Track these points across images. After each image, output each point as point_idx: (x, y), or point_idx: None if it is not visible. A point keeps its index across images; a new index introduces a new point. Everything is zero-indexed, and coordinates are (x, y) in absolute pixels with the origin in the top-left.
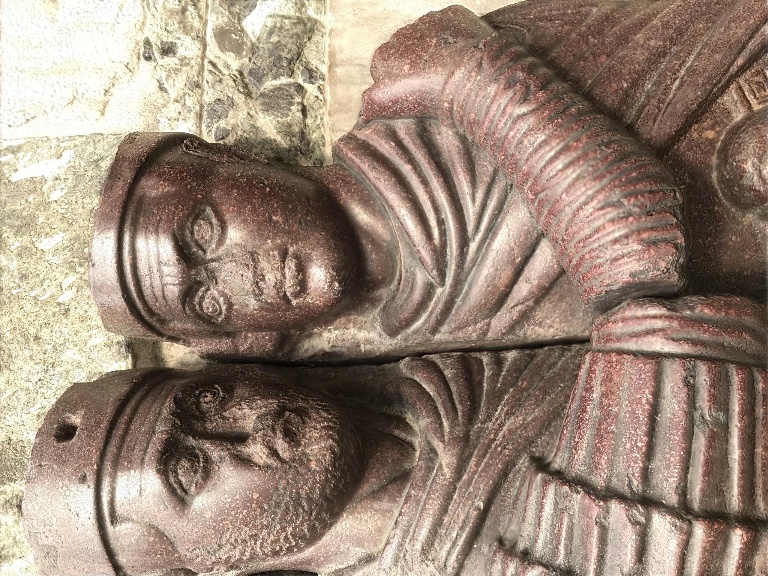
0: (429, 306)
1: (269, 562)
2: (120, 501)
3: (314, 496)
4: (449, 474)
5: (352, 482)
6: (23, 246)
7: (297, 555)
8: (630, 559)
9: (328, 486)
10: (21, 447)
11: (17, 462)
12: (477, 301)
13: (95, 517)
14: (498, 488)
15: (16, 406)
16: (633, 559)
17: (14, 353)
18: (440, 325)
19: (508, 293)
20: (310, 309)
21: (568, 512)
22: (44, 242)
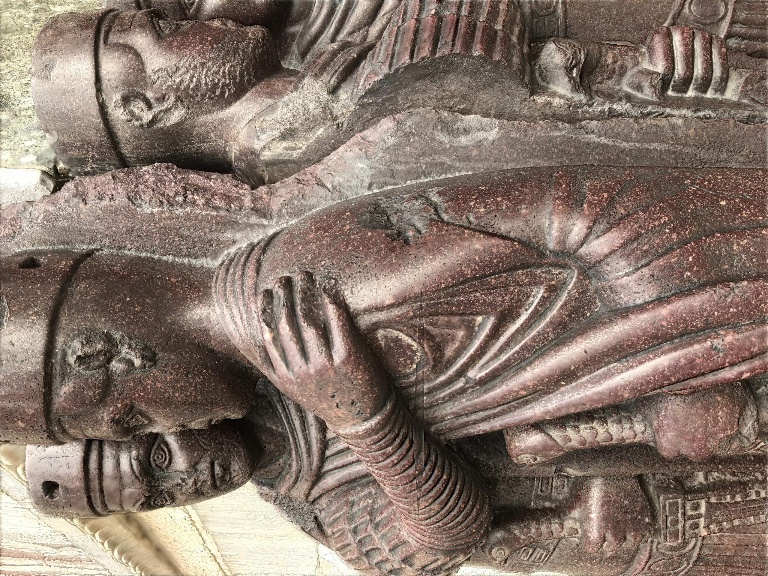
0: (331, 20)
1: (203, 116)
2: (114, 32)
3: (247, 51)
4: (337, 46)
5: (272, 65)
6: (40, 7)
7: (225, 110)
8: (436, 2)
9: (257, 50)
10: (7, 96)
11: (2, 102)
12: (362, 7)
13: (94, 35)
14: (366, 56)
15: (9, 78)
16: (438, 2)
17: (16, 53)
18: (337, 33)
19: (380, 5)
20: (255, 5)
21: (405, 4)
22: (57, 8)
